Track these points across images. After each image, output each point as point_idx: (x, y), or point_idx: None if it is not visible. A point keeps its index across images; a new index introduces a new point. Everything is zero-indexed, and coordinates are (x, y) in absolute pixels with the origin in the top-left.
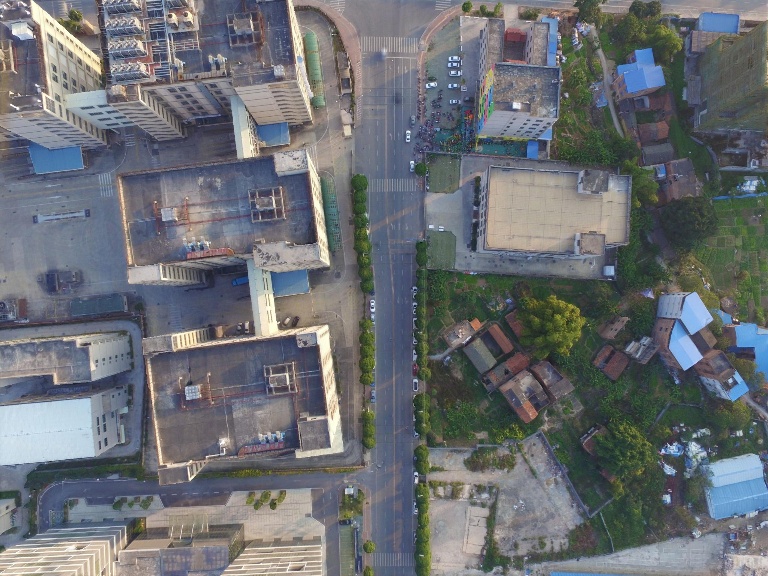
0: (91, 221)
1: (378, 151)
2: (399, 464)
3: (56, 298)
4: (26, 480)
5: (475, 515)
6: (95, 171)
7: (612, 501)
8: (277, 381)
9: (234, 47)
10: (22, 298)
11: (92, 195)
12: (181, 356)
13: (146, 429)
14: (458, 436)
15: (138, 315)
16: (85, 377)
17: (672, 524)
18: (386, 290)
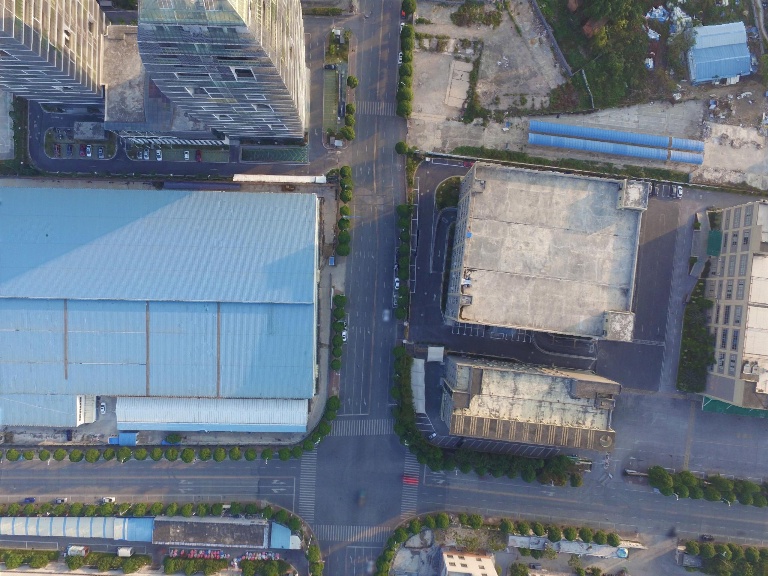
0: None
1: None
2: (387, 15)
3: None
4: None
5: (459, 69)
6: None
7: (595, 60)
8: None
9: None
10: None
11: None
12: None
13: None
14: None
15: None
16: None
17: (653, 89)
18: None
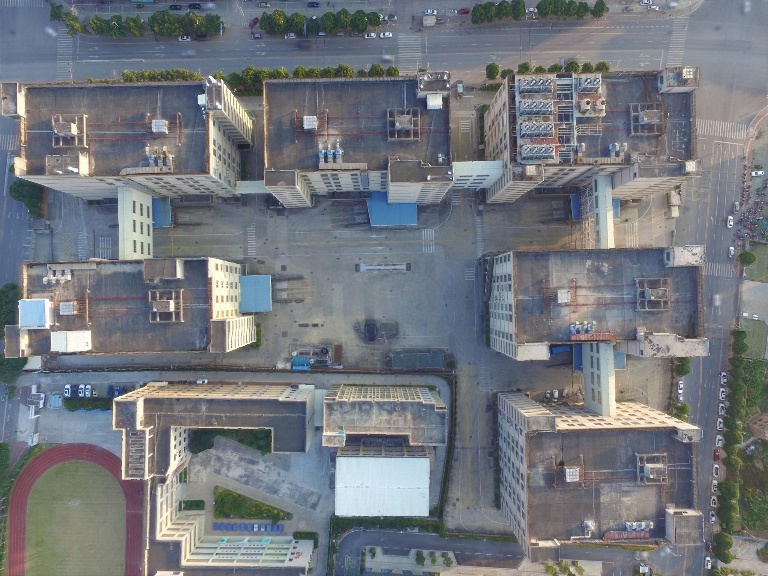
0: (411, 275)
1: (698, 233)
2: (691, 547)
3: (371, 347)
4: (326, 523)
5: None
6: (420, 226)
7: None
8: (657, 472)
9: (634, 135)
10: (338, 344)
11: (414, 249)
12: (555, 435)
13: (448, 486)
14: (757, 527)
15: None
16: (437, 440)
17: None
18: (694, 373)
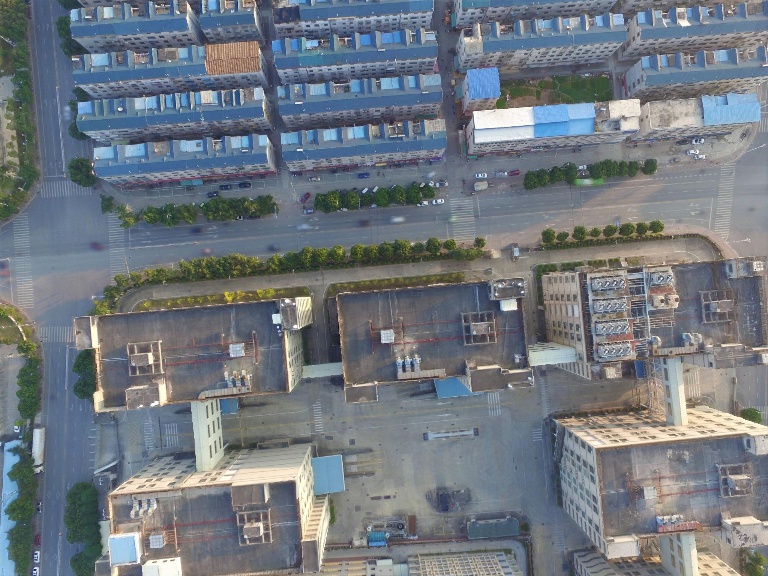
0: (479, 440)
1: (758, 378)
2: None
3: (444, 515)
4: None
5: None
6: None
7: None
8: None
9: (706, 323)
10: (412, 514)
11: (481, 414)
12: None
13: None
14: None
15: (528, 537)
16: None
17: None
18: None
